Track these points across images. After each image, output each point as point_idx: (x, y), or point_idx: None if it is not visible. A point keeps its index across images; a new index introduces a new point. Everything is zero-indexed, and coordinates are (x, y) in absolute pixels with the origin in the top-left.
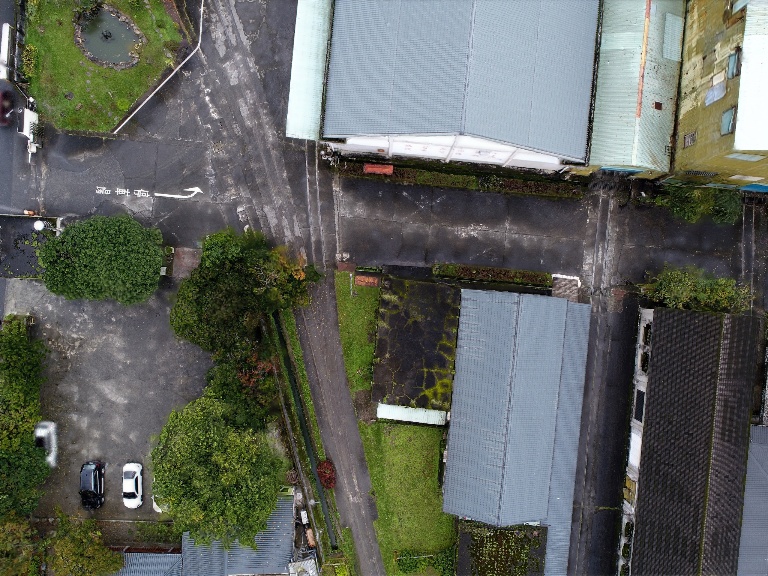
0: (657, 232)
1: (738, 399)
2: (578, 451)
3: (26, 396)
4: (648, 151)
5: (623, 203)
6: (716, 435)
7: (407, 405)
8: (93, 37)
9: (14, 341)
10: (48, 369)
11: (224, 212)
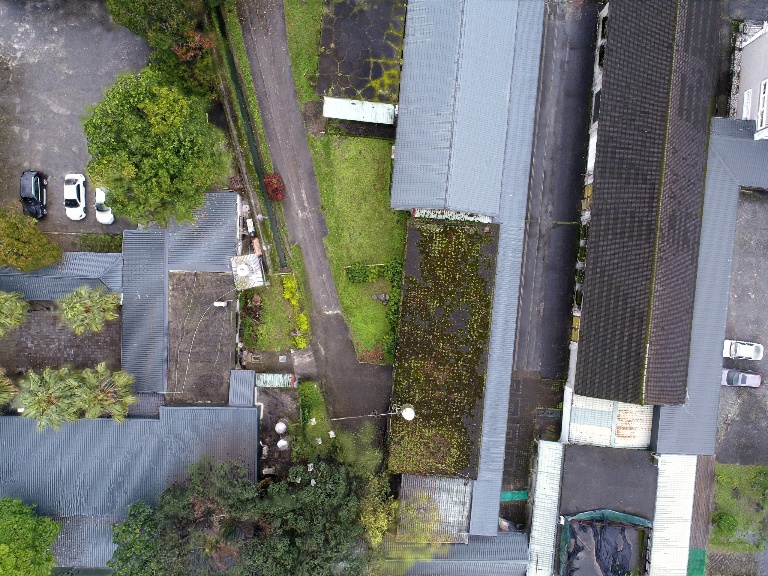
0: None
1: (697, 80)
2: (535, 164)
3: None
4: None
5: None
6: (673, 109)
7: (353, 97)
8: None
9: None
10: None
11: None
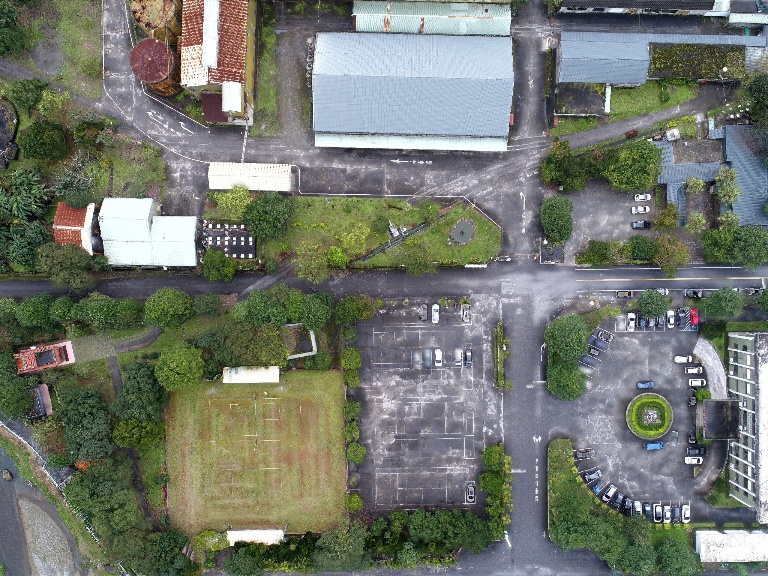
0: (527, 8)
1: None
2: None
3: None
4: (504, 13)
5: (516, 22)
6: None
7: None
8: (463, 239)
9: (590, 248)
10: None
11: (529, 182)
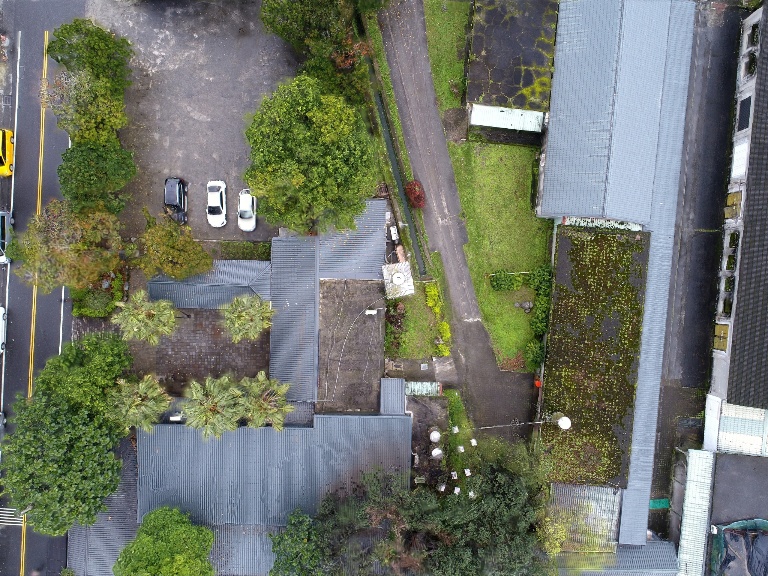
0: None
1: None
2: None
3: (111, 96)
4: None
5: None
6: None
7: (504, 104)
8: None
9: (101, 32)
10: (129, 87)
11: None
